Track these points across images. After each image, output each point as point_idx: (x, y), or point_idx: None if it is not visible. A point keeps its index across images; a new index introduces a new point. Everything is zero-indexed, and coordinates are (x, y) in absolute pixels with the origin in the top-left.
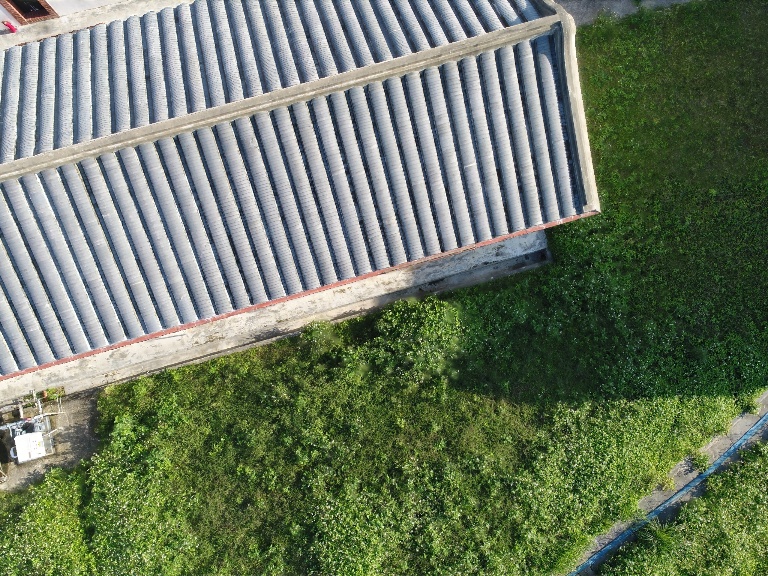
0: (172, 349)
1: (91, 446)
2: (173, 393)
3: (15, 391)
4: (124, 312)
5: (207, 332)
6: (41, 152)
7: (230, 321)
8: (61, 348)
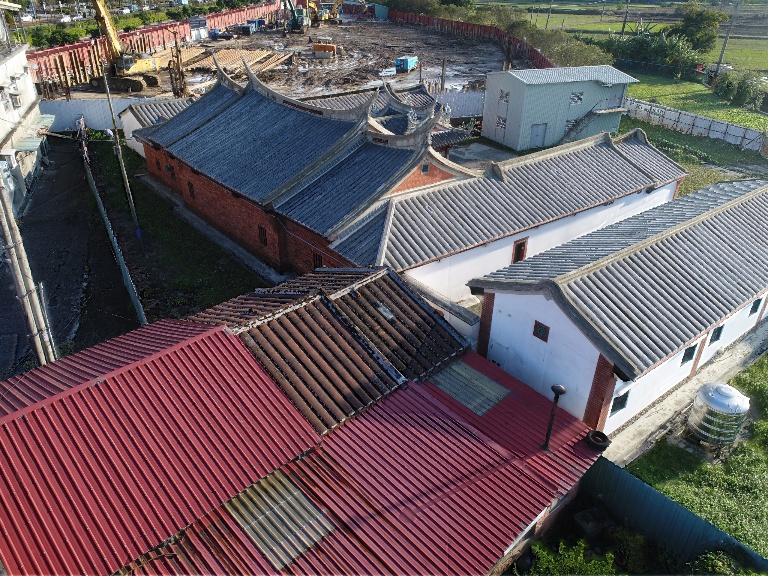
0: (733, 363)
1: (754, 412)
2: (763, 372)
3: (681, 402)
4: (763, 270)
5: (739, 352)
6: None
7: (743, 346)
8: (755, 287)
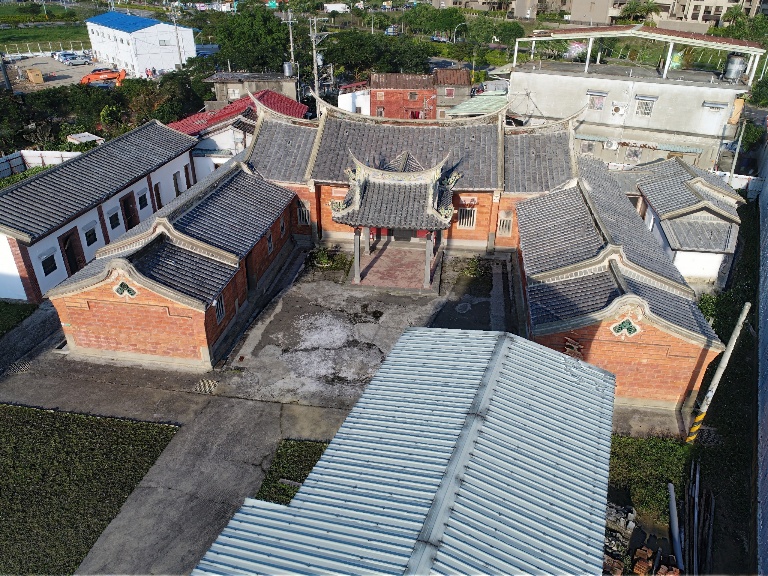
0: None
1: None
2: None
3: None
4: None
5: None
6: (87, 157)
7: None
8: None
